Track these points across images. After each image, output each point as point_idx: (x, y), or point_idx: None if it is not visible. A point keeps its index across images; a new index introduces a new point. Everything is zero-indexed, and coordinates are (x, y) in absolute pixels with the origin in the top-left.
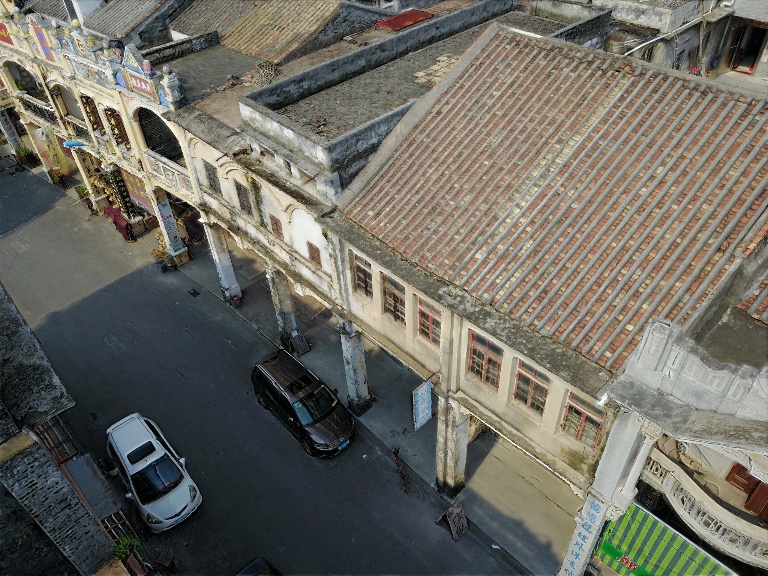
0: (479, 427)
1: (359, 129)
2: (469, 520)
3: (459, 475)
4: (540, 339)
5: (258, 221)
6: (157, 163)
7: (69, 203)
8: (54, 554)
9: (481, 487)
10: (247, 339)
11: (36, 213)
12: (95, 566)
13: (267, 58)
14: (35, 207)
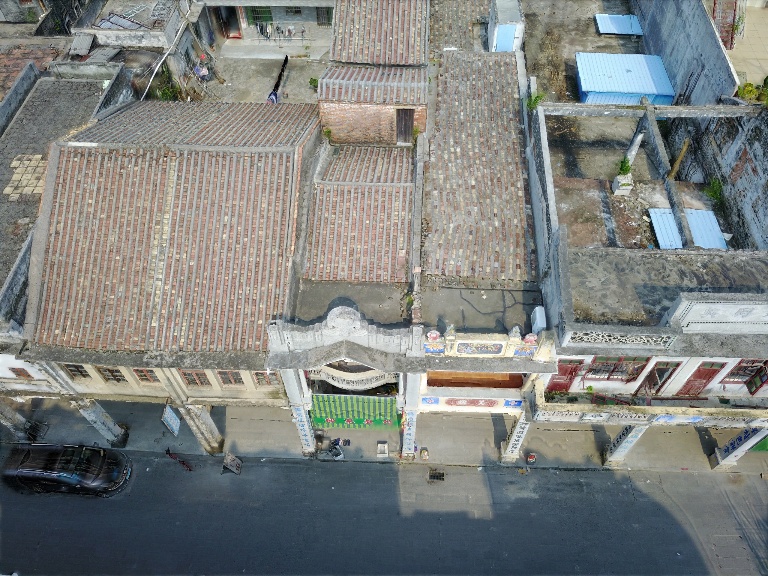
0: None
1: (8, 282)
2: (239, 457)
3: (217, 437)
4: (219, 354)
5: None
6: None
7: None
8: None
9: (234, 433)
10: None
11: None
12: None
13: None
14: None
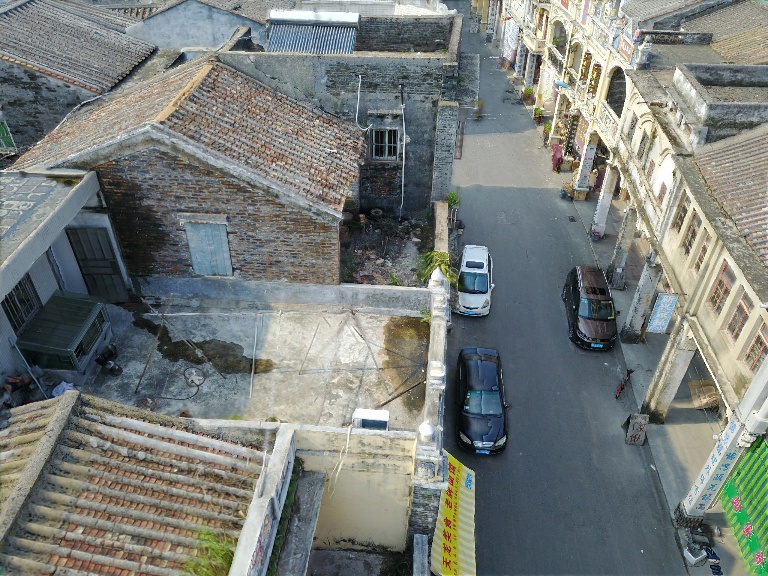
0: (711, 403)
1: (745, 103)
2: (648, 442)
3: (663, 405)
4: (761, 267)
5: (642, 165)
6: (605, 113)
7: (534, 134)
8: (429, 179)
9: (676, 433)
10: (585, 261)
11: (511, 131)
12: (438, 197)
13: (737, 63)
14: (512, 127)
